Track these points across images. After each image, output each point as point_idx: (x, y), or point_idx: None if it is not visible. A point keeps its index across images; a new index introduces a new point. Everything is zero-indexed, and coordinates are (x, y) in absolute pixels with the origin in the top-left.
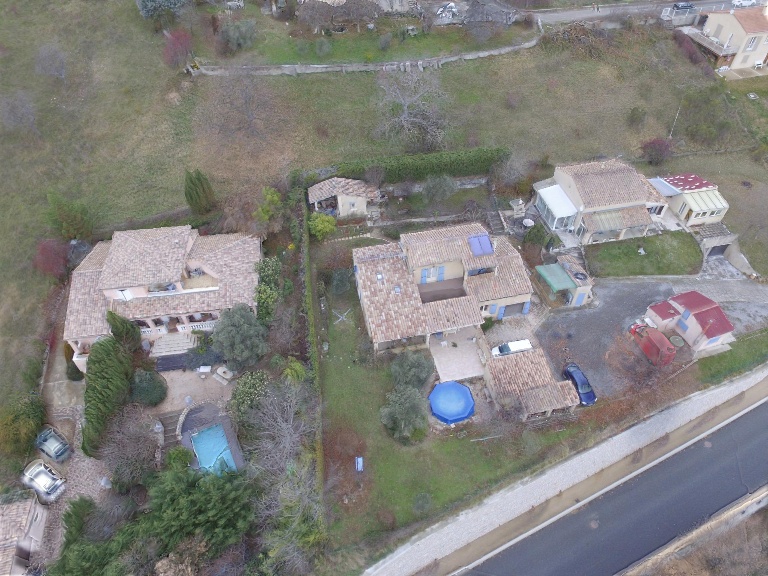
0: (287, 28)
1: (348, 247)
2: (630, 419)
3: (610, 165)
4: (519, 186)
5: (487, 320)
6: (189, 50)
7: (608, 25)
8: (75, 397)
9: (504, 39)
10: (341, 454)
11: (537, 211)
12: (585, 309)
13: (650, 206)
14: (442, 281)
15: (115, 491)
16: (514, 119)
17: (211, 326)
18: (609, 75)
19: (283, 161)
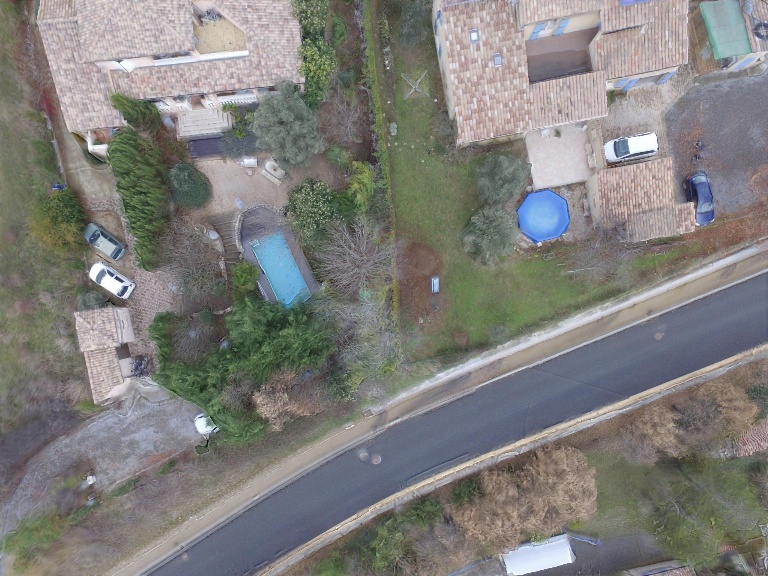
0: None
1: None
2: (742, 244)
3: None
4: None
5: (607, 97)
6: None
7: None
8: (108, 189)
9: None
10: (416, 273)
11: None
12: (744, 77)
13: None
14: (560, 35)
15: (189, 300)
16: None
17: (246, 101)
18: None
19: None
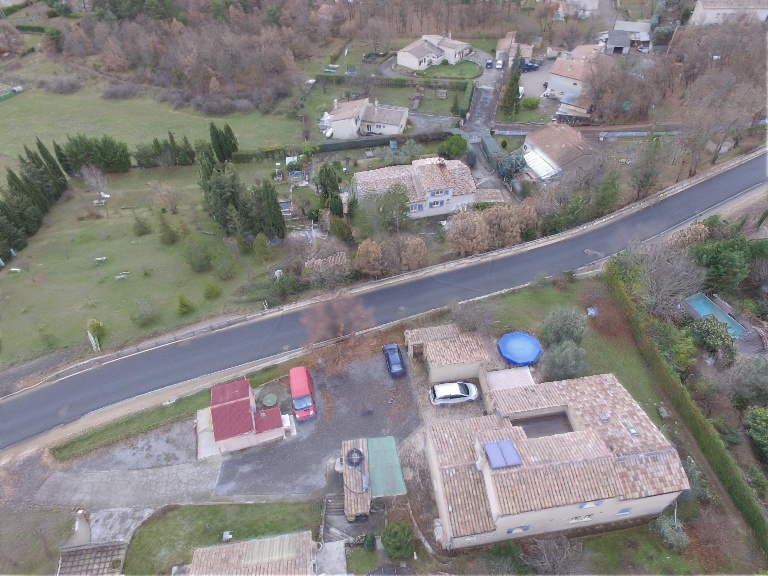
0: None
1: (704, 570)
2: None
3: None
4: None
5: None
6: None
7: None
8: None
9: None
10: None
11: None
12: None
13: None
14: None
15: None
16: None
17: None
18: None
19: None
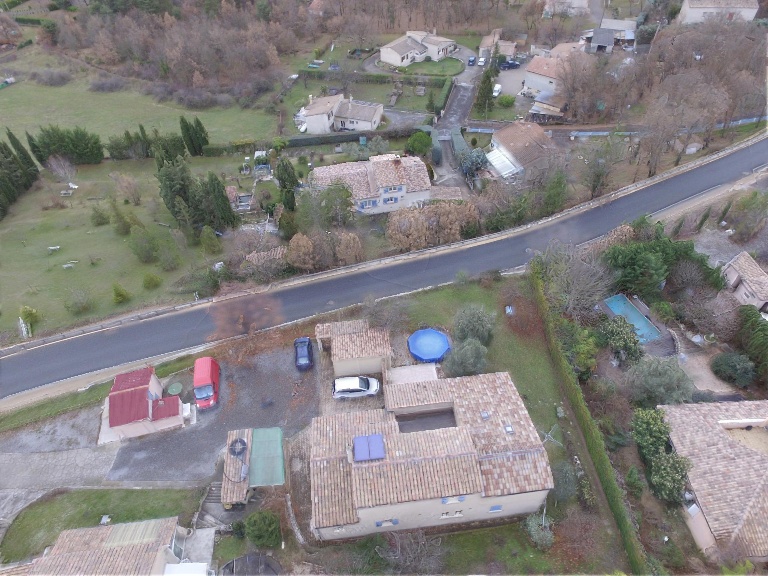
0: None
1: (565, 570)
2: None
3: None
4: None
5: None
6: None
7: None
8: None
9: None
10: None
11: None
12: None
13: None
14: None
15: None
16: None
17: None
18: None
19: None
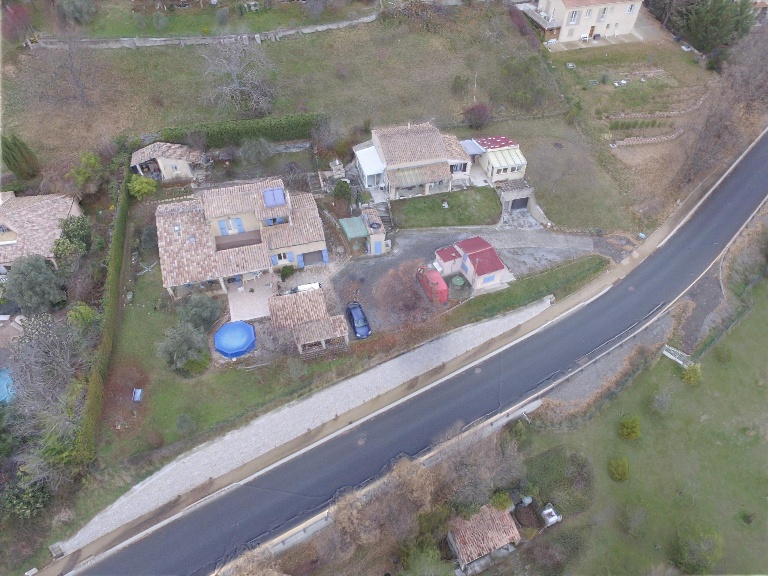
0: (132, 4)
1: None
2: (399, 348)
3: (420, 127)
4: (338, 148)
5: (286, 268)
6: (28, 24)
7: (449, 2)
8: None
9: (344, 14)
10: (123, 387)
11: (357, 172)
12: (384, 257)
13: (453, 163)
14: (244, 233)
15: None
16: (345, 88)
17: None
18: (441, 47)
19: (117, 129)
